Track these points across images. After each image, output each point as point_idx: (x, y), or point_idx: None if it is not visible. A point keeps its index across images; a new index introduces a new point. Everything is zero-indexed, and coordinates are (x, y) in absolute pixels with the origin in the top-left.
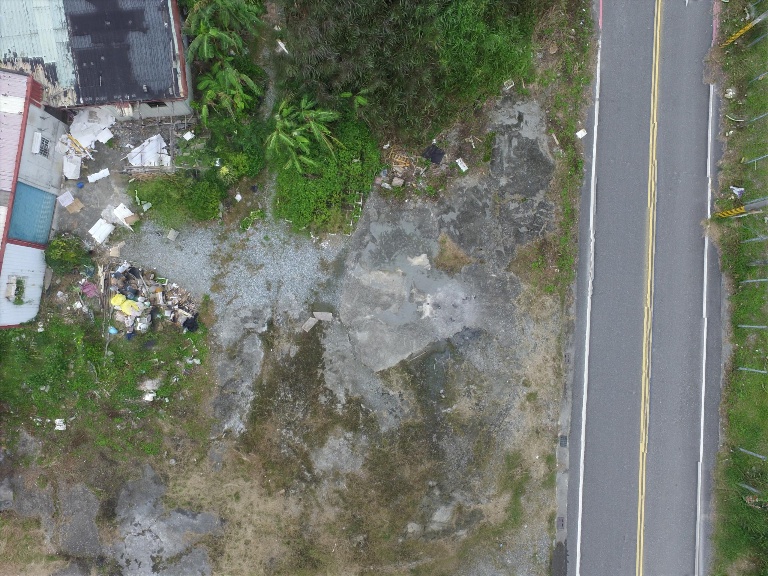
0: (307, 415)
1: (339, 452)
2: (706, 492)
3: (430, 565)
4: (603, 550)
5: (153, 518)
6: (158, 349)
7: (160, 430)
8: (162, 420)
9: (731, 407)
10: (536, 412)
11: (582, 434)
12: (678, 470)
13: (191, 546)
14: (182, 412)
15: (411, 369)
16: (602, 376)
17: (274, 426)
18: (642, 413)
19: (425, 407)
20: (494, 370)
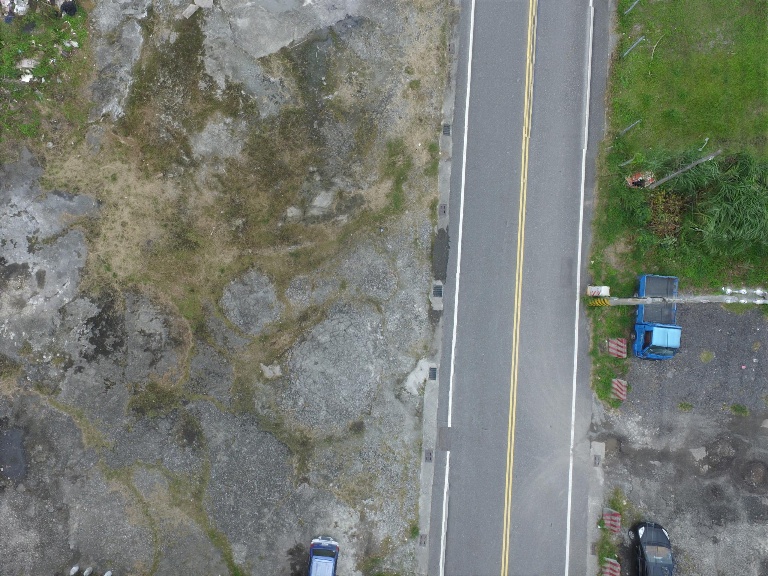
0: (187, 101)
1: (218, 137)
2: (591, 179)
3: (309, 249)
4: (485, 235)
5: (29, 199)
6: (36, 33)
7: (37, 112)
8: (39, 103)
9: (617, 95)
10: (419, 99)
11: (465, 121)
12: (562, 157)
13: (67, 227)
14: (60, 96)
15: (292, 56)
16: (486, 65)
17: (153, 111)
18: (526, 99)
19: (306, 94)
20: (377, 58)
